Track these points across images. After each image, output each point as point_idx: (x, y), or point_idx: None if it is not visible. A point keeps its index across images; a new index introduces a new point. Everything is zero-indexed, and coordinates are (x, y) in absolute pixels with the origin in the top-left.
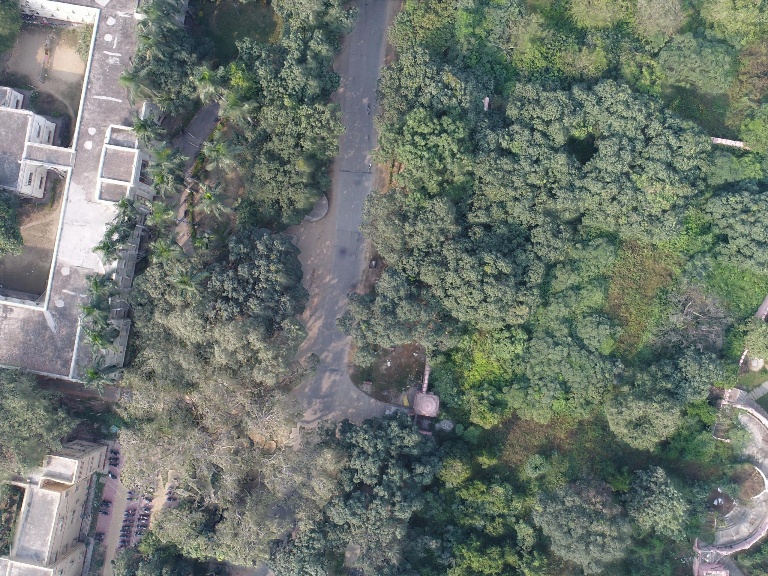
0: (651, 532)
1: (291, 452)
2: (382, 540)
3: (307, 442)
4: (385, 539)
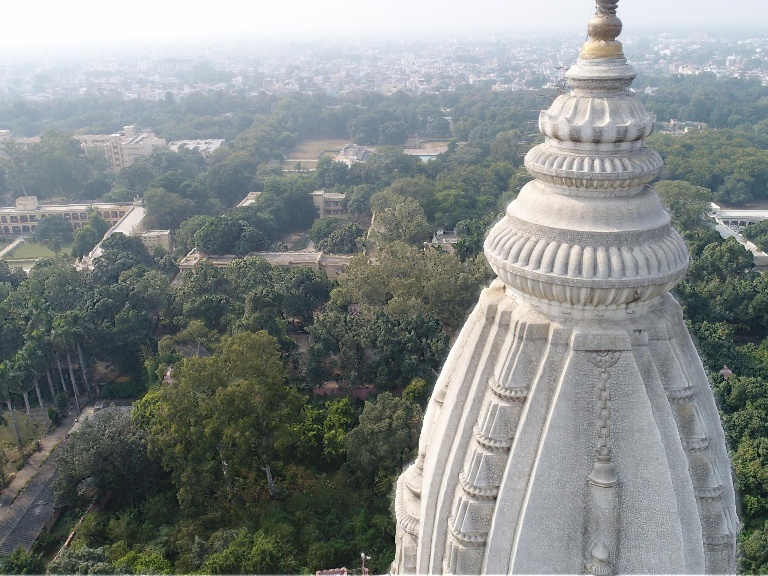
0: (381, 534)
1: (417, 288)
2: (360, 335)
3: (421, 311)
4: (360, 337)
